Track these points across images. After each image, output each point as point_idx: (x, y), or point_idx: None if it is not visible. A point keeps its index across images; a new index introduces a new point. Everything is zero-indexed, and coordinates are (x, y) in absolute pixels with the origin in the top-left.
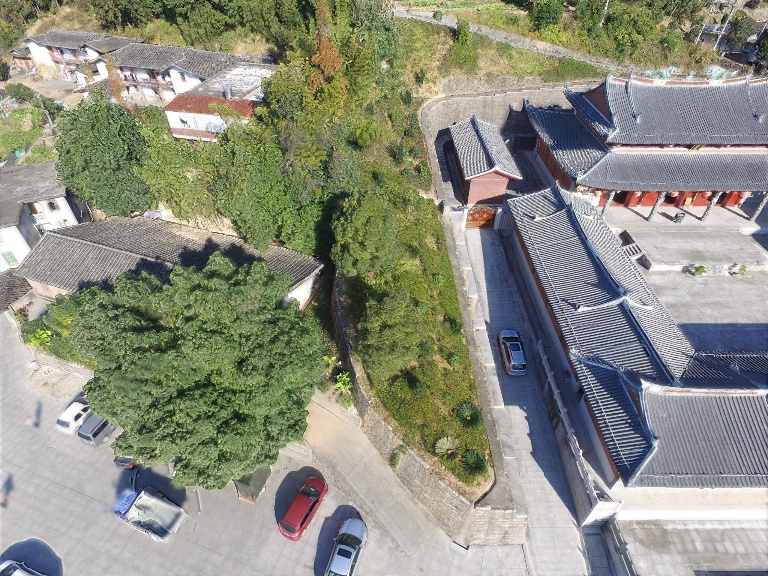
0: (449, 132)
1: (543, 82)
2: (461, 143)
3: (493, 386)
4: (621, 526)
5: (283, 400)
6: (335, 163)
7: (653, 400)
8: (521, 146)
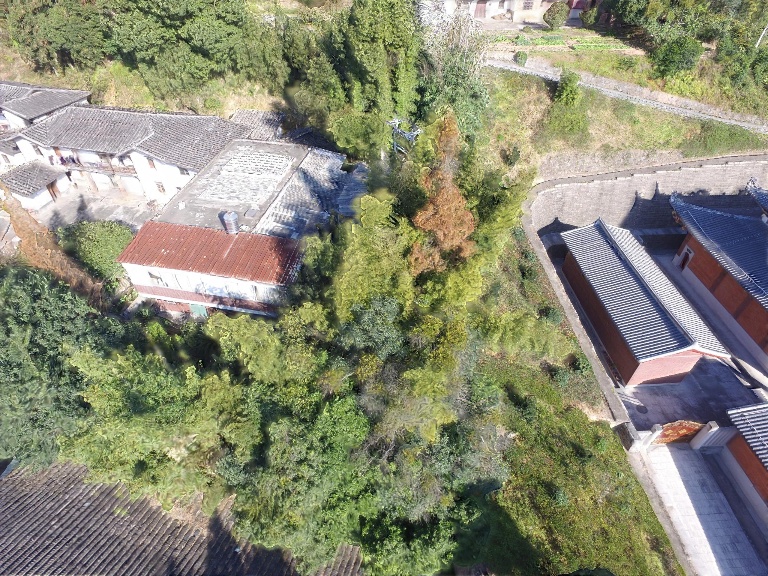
0: (548, 231)
1: (682, 157)
2: (596, 273)
3: None
4: None
5: None
6: (481, 443)
7: None
8: (649, 247)
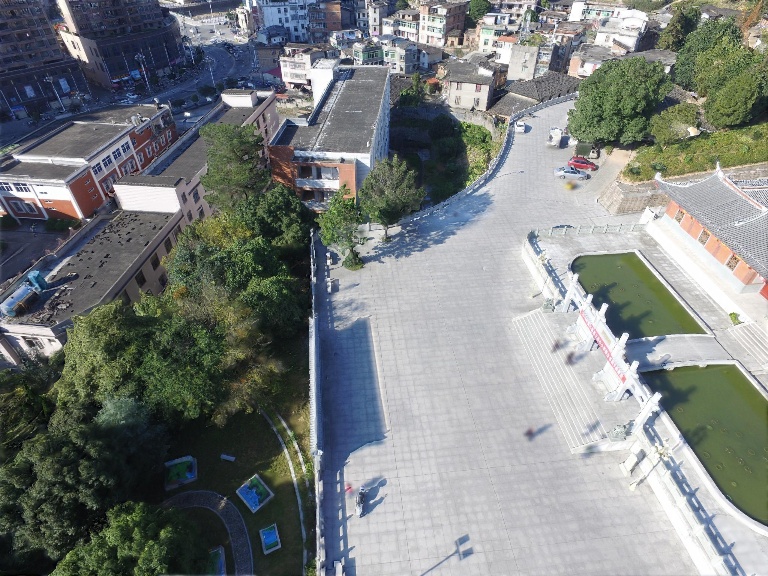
0: None
1: None
2: None
3: None
4: (645, 233)
5: (614, 105)
6: None
7: (714, 179)
8: None
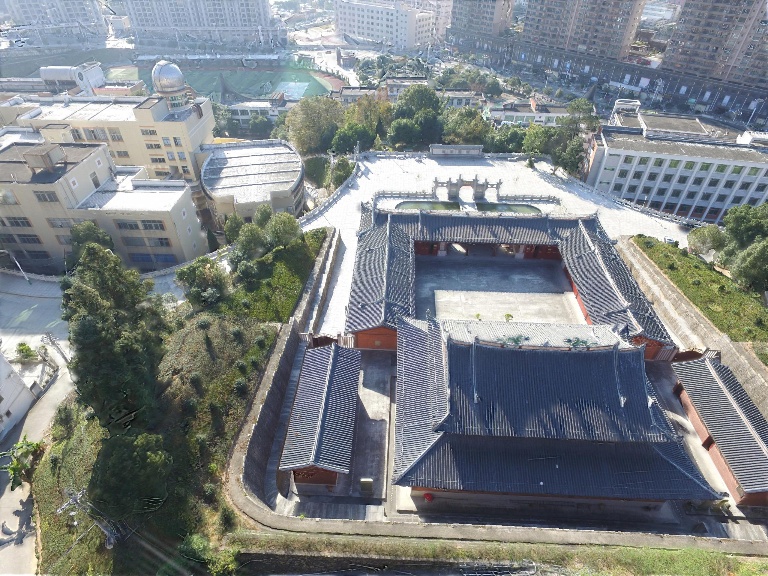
0: None
1: None
2: None
3: (638, 265)
4: None
5: None
6: None
7: None
8: None
